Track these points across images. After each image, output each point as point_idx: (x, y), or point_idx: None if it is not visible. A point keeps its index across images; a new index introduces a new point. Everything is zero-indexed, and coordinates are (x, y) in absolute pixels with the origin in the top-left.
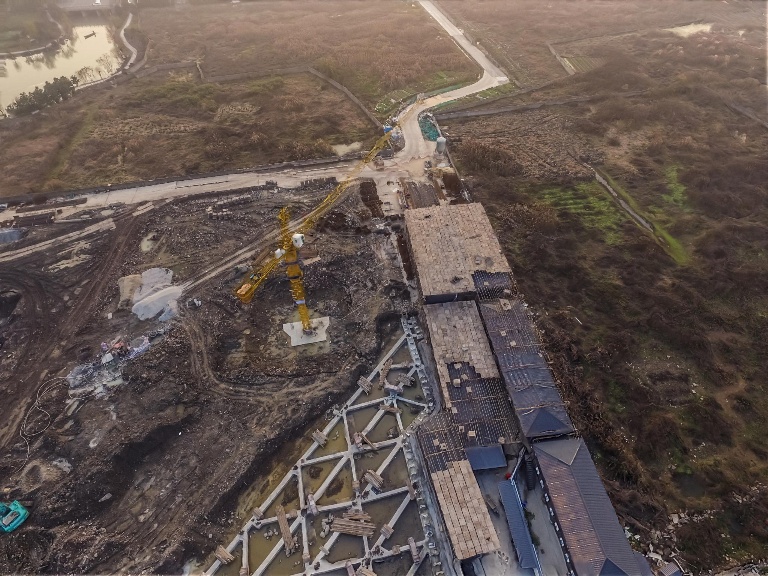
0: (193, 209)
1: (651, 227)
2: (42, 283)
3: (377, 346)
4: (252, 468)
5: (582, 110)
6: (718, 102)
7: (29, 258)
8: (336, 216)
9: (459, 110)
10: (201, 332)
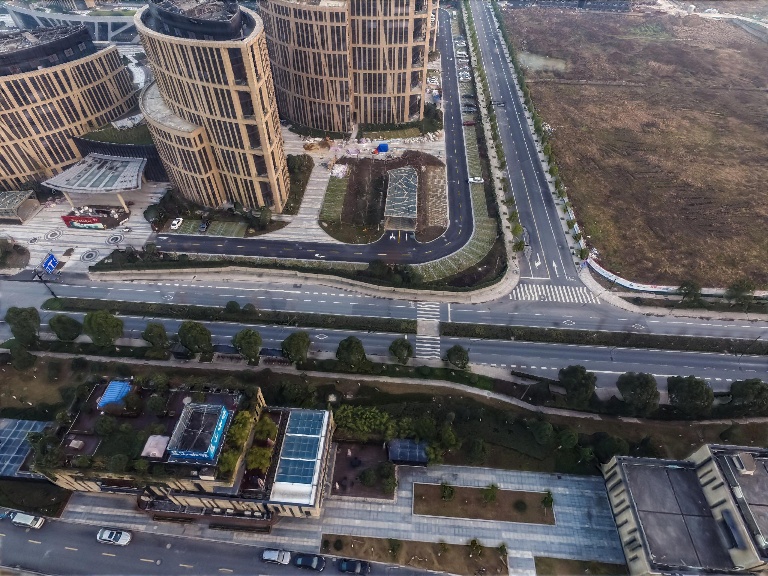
0: None
1: None
2: None
3: None
4: None
5: (765, 48)
6: None
7: None
8: None
9: (749, 26)
10: None
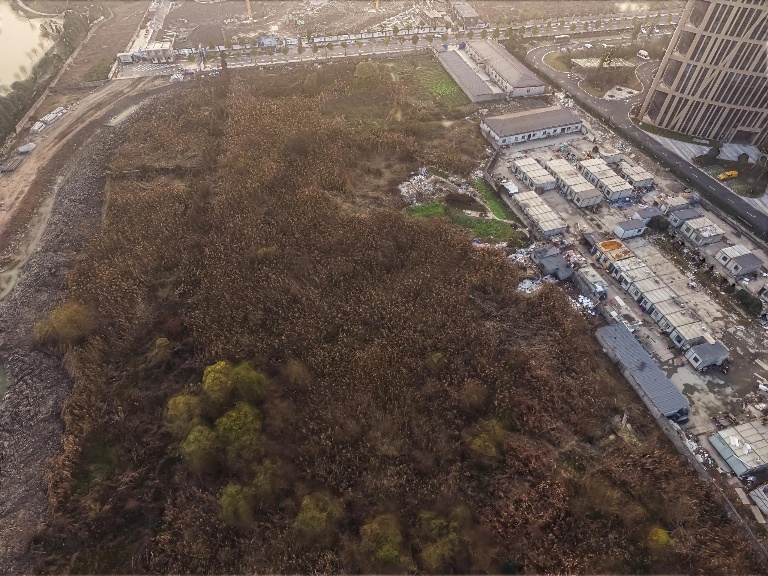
0: None
1: None
2: (270, 0)
3: (404, 8)
4: (367, 22)
5: None
6: None
7: None
8: None
9: None
10: (339, 6)
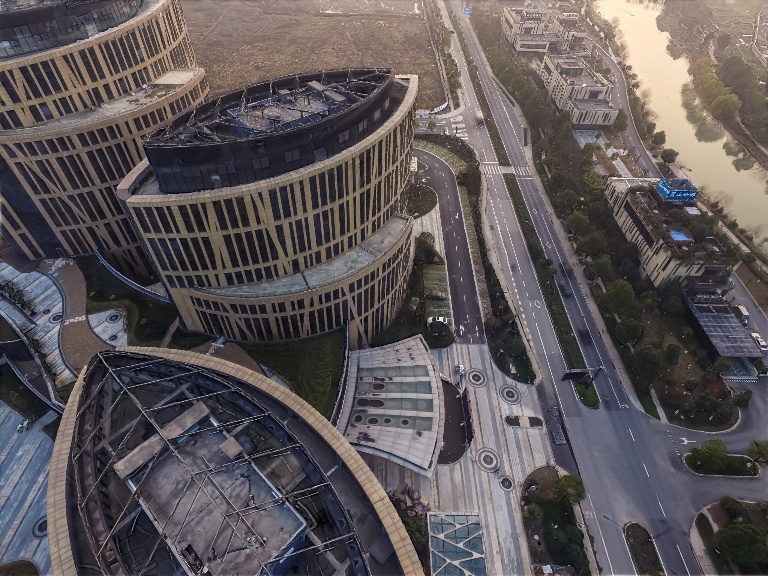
0: None
1: None
2: None
3: None
4: None
5: None
6: (216, 15)
7: None
8: None
9: None
10: None
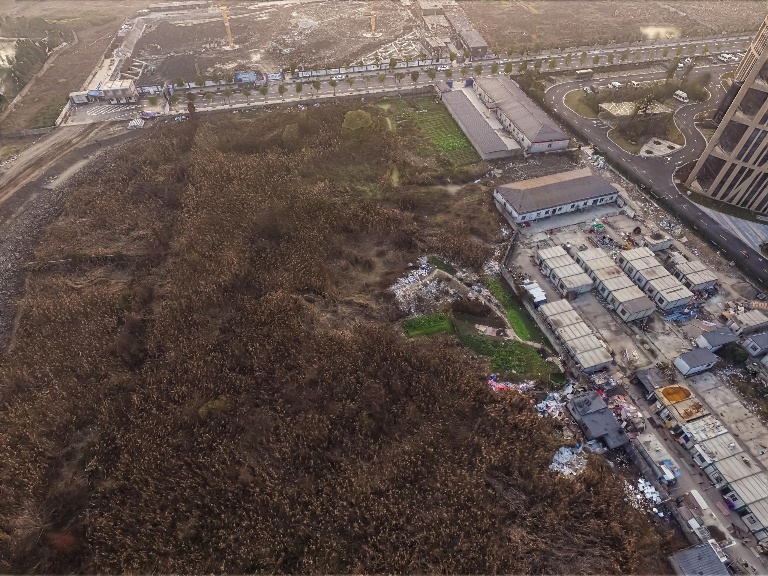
0: (312, 6)
1: (527, 7)
2: (255, 22)
3: None
4: None
5: None
6: None
7: (243, 17)
8: (381, 6)
9: None
10: None
